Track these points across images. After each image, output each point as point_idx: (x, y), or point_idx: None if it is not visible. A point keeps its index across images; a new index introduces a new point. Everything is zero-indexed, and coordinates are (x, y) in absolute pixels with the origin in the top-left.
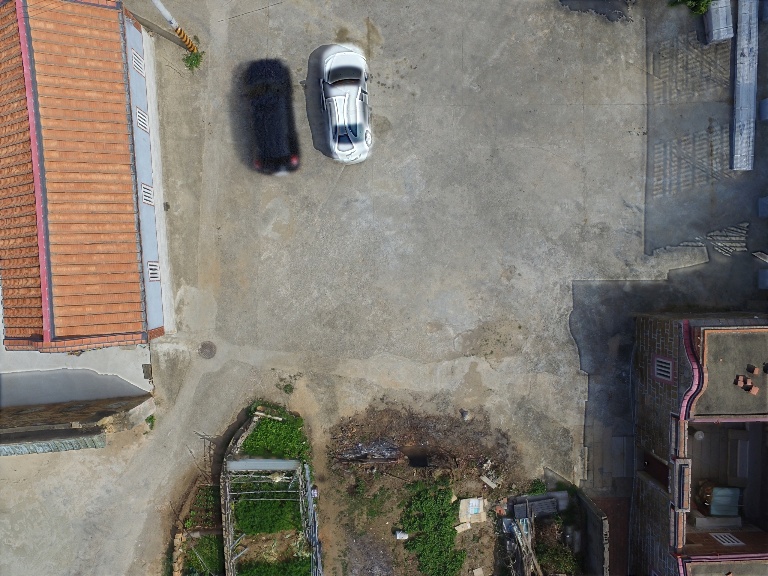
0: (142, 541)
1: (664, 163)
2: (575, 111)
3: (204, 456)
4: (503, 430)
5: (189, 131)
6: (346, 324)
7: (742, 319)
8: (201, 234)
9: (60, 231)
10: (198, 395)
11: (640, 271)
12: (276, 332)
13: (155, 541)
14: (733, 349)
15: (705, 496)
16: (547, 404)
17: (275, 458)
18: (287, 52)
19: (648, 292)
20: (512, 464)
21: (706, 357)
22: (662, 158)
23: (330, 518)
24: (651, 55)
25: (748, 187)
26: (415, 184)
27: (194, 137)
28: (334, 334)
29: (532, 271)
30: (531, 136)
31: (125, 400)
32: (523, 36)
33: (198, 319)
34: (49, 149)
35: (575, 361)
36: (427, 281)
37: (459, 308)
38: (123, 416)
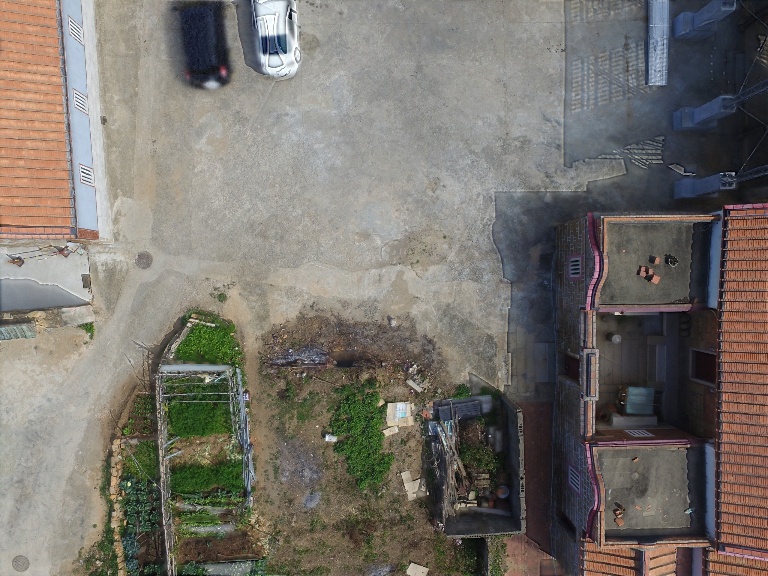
0: (83, 448)
1: (582, 79)
2: (496, 29)
3: (142, 365)
4: (429, 336)
5: (125, 48)
6: (277, 234)
7: (644, 212)
8: (137, 147)
9: None
10: (136, 305)
11: (560, 183)
12: (210, 242)
13: (95, 449)
14: (635, 240)
15: (623, 398)
16: (471, 311)
17: (208, 363)
18: None
19: (568, 203)
20: (438, 369)
21: (606, 244)
22: (580, 74)
23: (262, 422)
24: None
25: (663, 102)
26: (342, 99)
27: (130, 54)
28: (266, 244)
29: (456, 183)
30: (454, 53)
31: None
32: None
33: (135, 229)
34: None
35: (498, 270)
36: (355, 192)
37: (386, 219)
38: (56, 313)
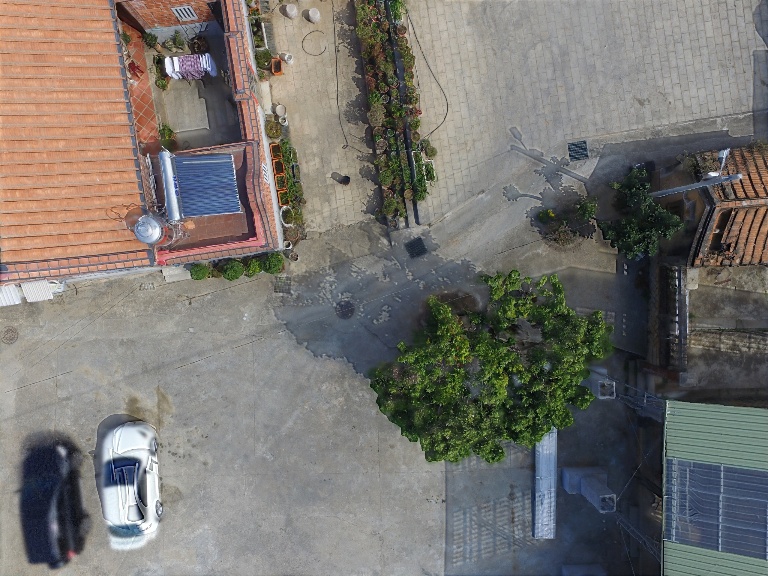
0: None
1: (464, 530)
2: (371, 479)
3: None
4: None
5: None
6: None
7: None
8: None
9: None
10: None
11: None
12: None
13: None
14: None
15: None
16: None
17: None
18: (75, 422)
19: None
20: None
21: None
22: (462, 526)
23: None
24: None
25: (552, 554)
26: (207, 554)
27: None
28: None
29: None
30: (326, 505)
31: None
32: (316, 404)
33: None
34: None
35: None
36: None
37: None
38: None
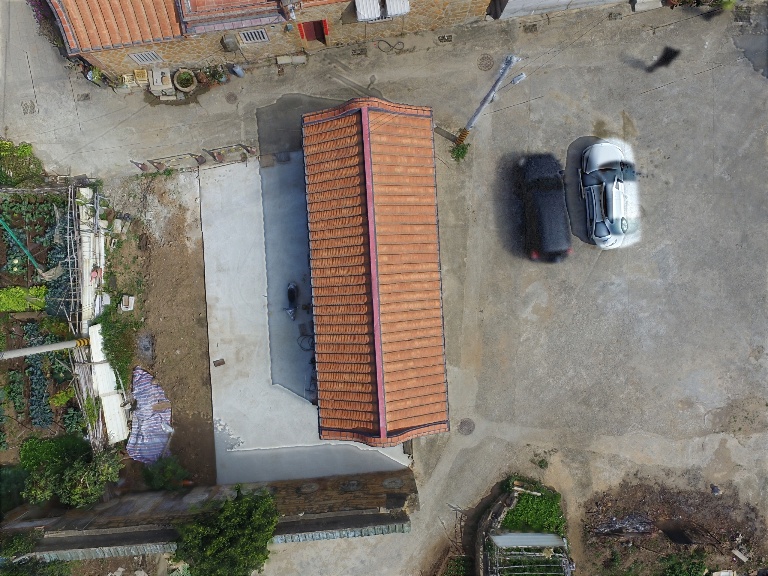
0: None
1: None
2: None
3: (455, 527)
4: (752, 504)
5: (455, 219)
6: (600, 402)
7: None
8: (465, 316)
9: (388, 330)
10: (454, 469)
11: None
12: (533, 410)
13: None
14: None
15: None
16: None
17: (534, 532)
18: (547, 143)
19: None
20: (761, 538)
21: None
22: None
23: None
24: None
25: None
26: (668, 268)
27: (459, 224)
28: (589, 412)
29: None
30: None
31: (390, 476)
32: None
33: (459, 397)
34: (380, 253)
35: None
36: (679, 361)
37: (709, 387)
38: (414, 498)
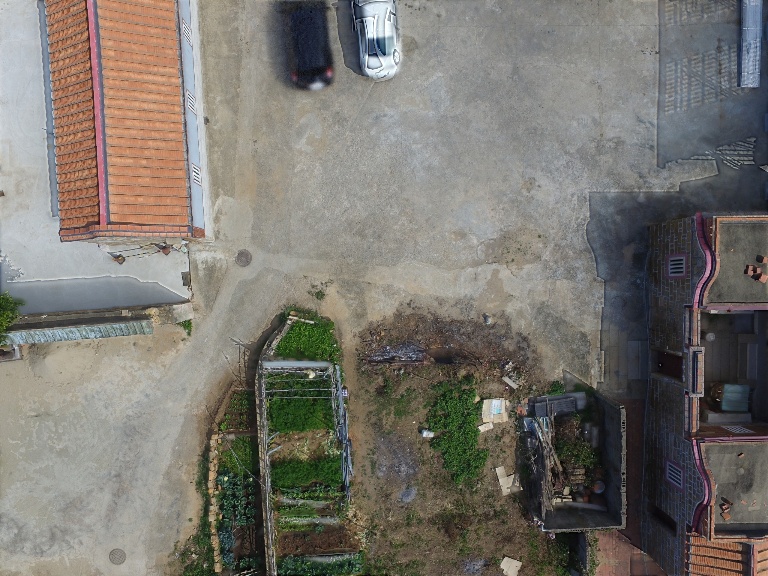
0: (179, 443)
1: (675, 81)
2: (591, 32)
3: (239, 362)
4: (524, 334)
5: (228, 50)
6: (375, 233)
7: (751, 212)
8: (238, 147)
9: (115, 124)
10: (234, 302)
11: (653, 183)
12: (308, 241)
13: (192, 444)
14: (743, 240)
15: (717, 395)
16: (565, 309)
17: (307, 360)
18: None
19: (661, 203)
20: (532, 366)
21: (718, 244)
22: (673, 76)
23: (359, 418)
24: None
25: (755, 104)
26: (440, 100)
27: (232, 55)
28: (363, 243)
29: (551, 183)
30: (549, 55)
31: None
32: None
33: (235, 228)
34: (105, 48)
35: (592, 268)
36: (451, 192)
37: (482, 218)
38: (168, 310)
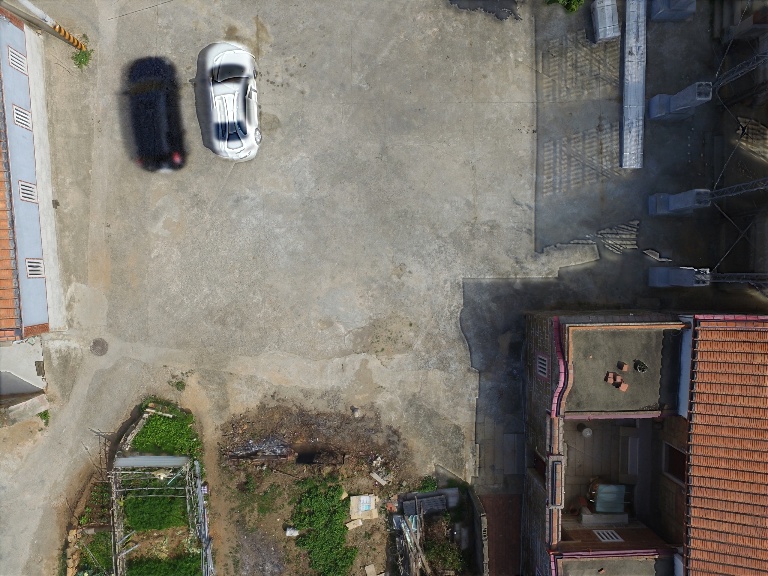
0: (38, 537)
1: (554, 161)
2: (464, 109)
3: (99, 453)
4: (394, 427)
5: (78, 129)
6: (237, 321)
7: (612, 316)
8: (91, 231)
9: None
10: (91, 392)
11: (530, 269)
12: (167, 329)
13: (51, 537)
14: (603, 346)
15: (593, 493)
16: (438, 401)
17: (166, 455)
18: (176, 50)
19: (539, 290)
20: (403, 461)
21: (571, 354)
22: (552, 156)
23: (221, 515)
24: (540, 53)
25: (638, 185)
26: (305, 182)
27: (83, 135)
28: (225, 331)
29: (422, 269)
30: (420, 134)
31: (16, 397)
32: (412, 34)
33: (89, 316)
34: None
35: (466, 358)
36: (317, 278)
37: (350, 305)
38: (3, 412)
